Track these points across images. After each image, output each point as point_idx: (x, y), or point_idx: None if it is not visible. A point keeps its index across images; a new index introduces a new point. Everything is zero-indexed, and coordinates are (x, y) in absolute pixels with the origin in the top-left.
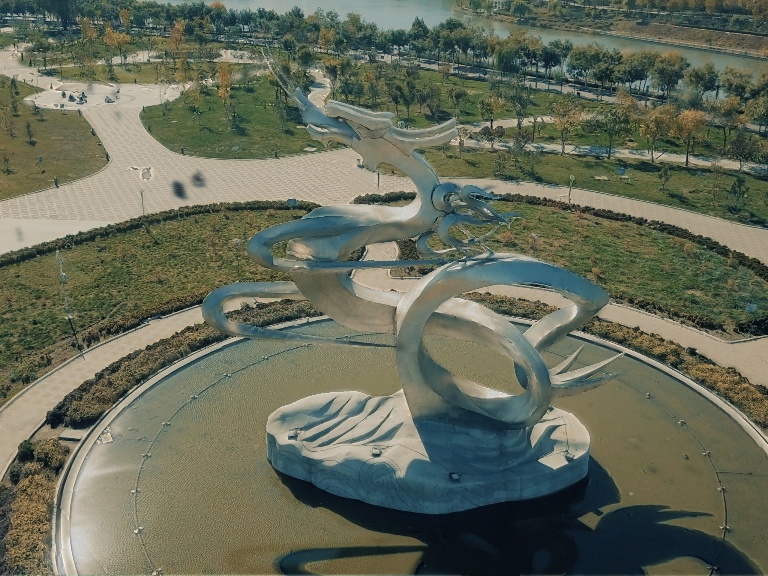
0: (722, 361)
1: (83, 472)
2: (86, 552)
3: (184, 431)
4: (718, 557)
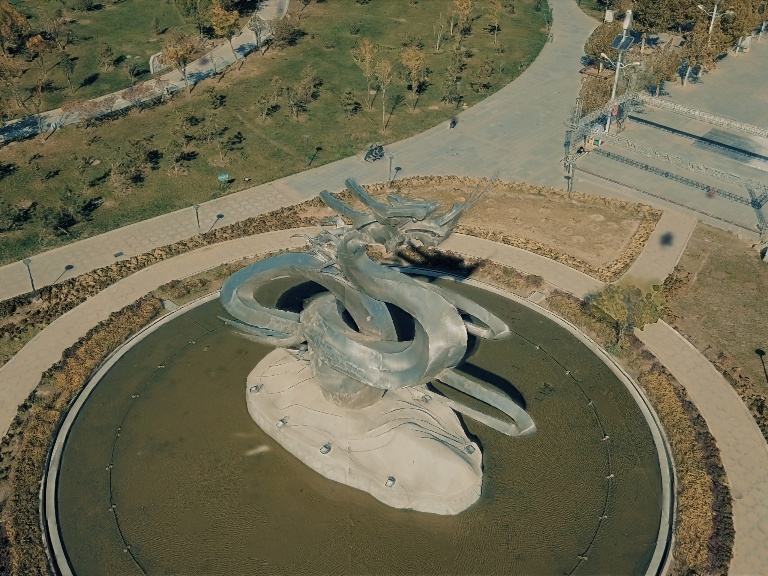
0: (24, 390)
1: (647, 564)
2: (652, 479)
3: (537, 575)
4: (295, 303)
